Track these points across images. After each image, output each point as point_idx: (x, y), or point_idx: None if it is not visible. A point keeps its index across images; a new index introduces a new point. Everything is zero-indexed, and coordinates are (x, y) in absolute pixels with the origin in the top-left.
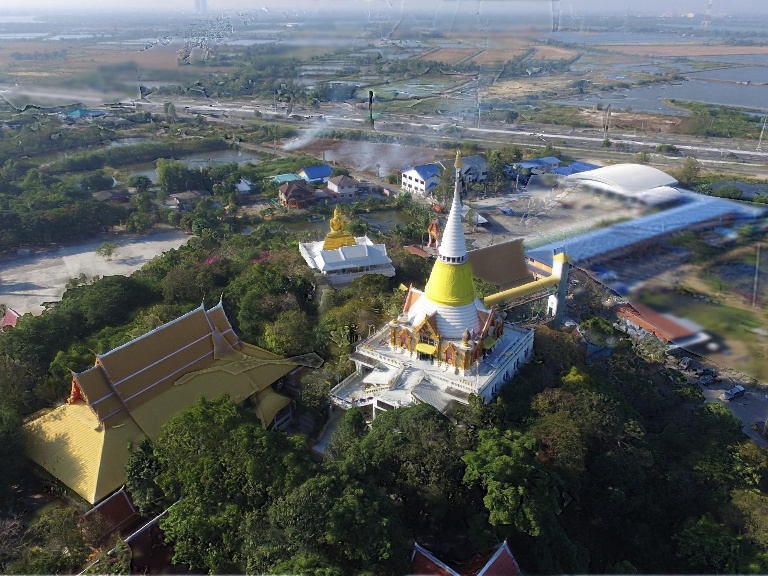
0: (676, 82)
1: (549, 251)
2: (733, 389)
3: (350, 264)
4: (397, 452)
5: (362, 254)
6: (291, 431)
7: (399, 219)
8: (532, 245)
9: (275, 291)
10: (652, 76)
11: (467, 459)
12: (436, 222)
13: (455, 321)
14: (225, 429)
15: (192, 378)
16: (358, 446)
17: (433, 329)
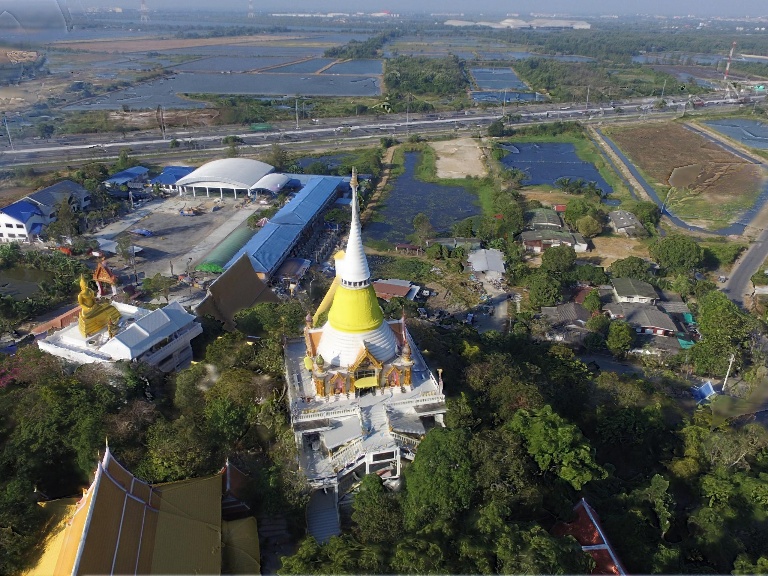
0: (169, 76)
1: (249, 258)
2: (468, 318)
3: (157, 338)
4: (480, 482)
5: (163, 321)
6: (268, 552)
7: (14, 278)
8: (218, 258)
9: (110, 408)
10: (142, 72)
11: (537, 450)
12: (104, 265)
13: (383, 343)
14: (380, 568)
15: (154, 567)
16: (431, 503)
17: (375, 359)
